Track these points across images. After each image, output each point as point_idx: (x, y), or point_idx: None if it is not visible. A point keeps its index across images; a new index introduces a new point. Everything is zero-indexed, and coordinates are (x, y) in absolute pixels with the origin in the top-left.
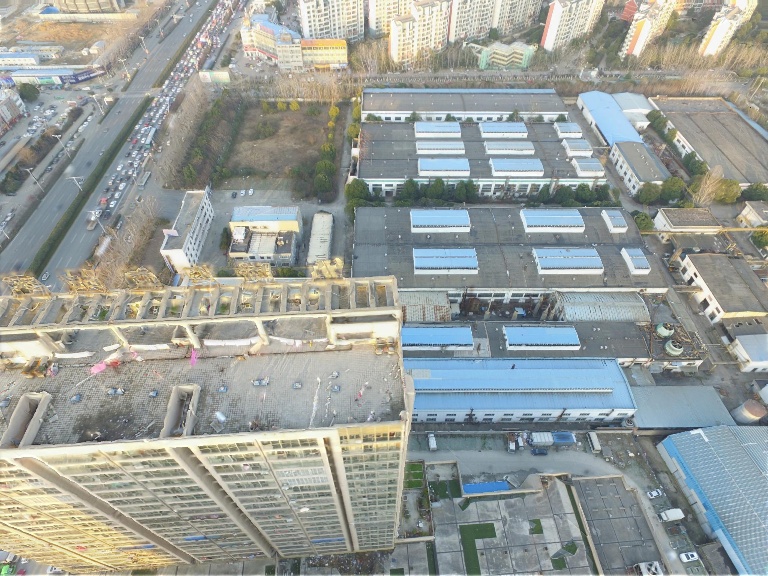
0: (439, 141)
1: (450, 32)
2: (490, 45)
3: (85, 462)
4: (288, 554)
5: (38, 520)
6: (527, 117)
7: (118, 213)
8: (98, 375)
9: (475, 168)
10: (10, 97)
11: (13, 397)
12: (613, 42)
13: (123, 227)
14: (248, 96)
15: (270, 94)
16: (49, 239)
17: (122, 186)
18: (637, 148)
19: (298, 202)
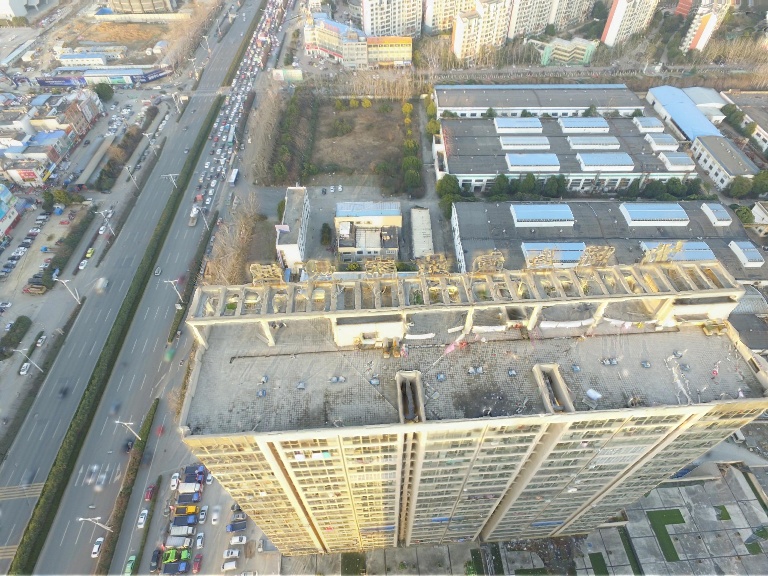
0: (523, 136)
1: (509, 28)
2: (551, 41)
3: (461, 437)
4: (491, 538)
5: (335, 498)
6: (603, 112)
7: (215, 210)
8: (449, 355)
9: (563, 163)
10: (91, 97)
11: (379, 376)
12: (672, 37)
13: (227, 223)
14: (320, 94)
15: (339, 92)
16: (155, 235)
17: (214, 183)
18: (721, 142)
19: (388, 198)
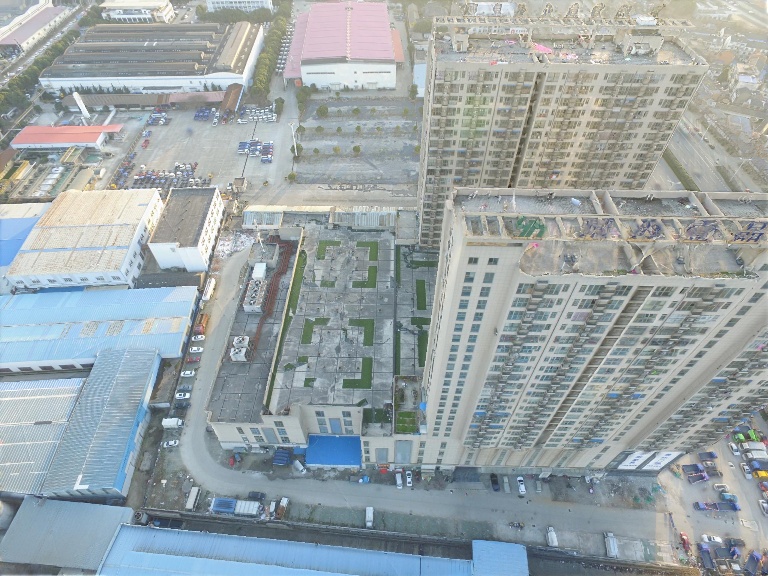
0: None
1: None
2: None
3: None
4: None
5: None
6: None
7: None
8: None
9: None
10: None
11: None
12: None
13: None
14: None
15: None
16: None
17: None
18: None
19: None
